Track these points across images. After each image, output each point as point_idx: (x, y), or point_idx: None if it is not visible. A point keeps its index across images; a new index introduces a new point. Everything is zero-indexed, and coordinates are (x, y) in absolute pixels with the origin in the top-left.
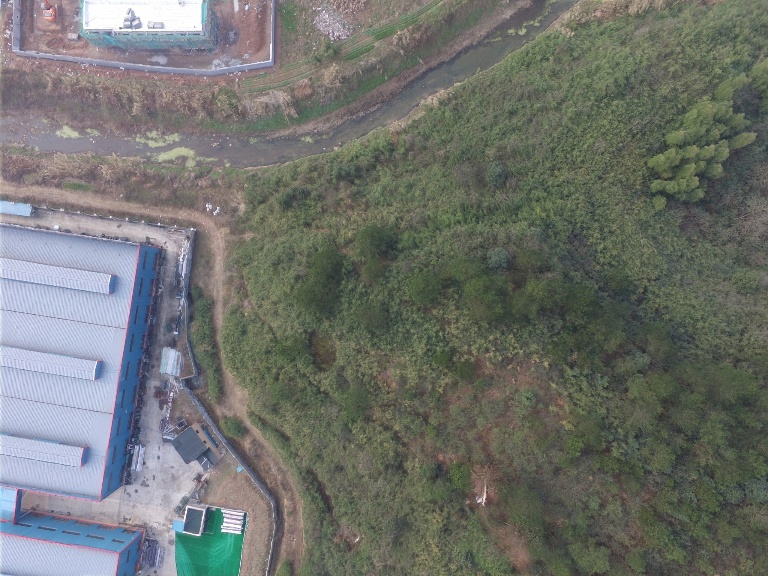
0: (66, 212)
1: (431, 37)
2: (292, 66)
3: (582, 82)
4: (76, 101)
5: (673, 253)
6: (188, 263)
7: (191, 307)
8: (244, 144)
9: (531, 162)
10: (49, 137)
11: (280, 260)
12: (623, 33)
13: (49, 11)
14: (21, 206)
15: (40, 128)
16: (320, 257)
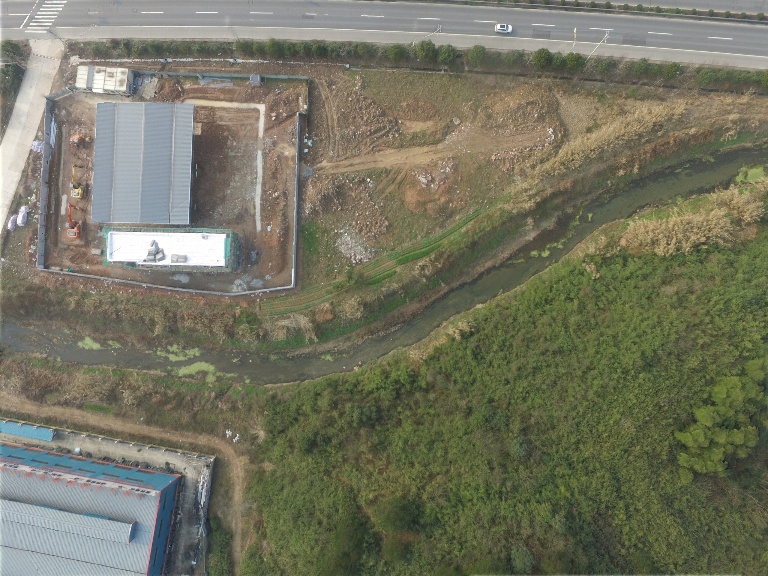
0: (87, 435)
1: (453, 262)
2: (313, 289)
3: (608, 351)
4: (98, 316)
5: (700, 528)
6: (207, 493)
7: (209, 536)
8: (264, 360)
9: (555, 434)
10: (71, 348)
11: (300, 514)
12: (650, 285)
13: (74, 230)
14: (43, 431)
15: (62, 339)
16: (342, 541)
